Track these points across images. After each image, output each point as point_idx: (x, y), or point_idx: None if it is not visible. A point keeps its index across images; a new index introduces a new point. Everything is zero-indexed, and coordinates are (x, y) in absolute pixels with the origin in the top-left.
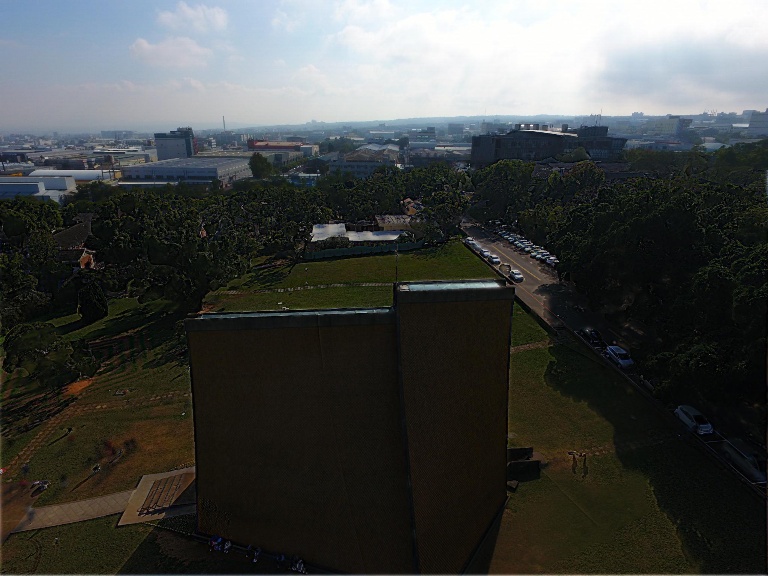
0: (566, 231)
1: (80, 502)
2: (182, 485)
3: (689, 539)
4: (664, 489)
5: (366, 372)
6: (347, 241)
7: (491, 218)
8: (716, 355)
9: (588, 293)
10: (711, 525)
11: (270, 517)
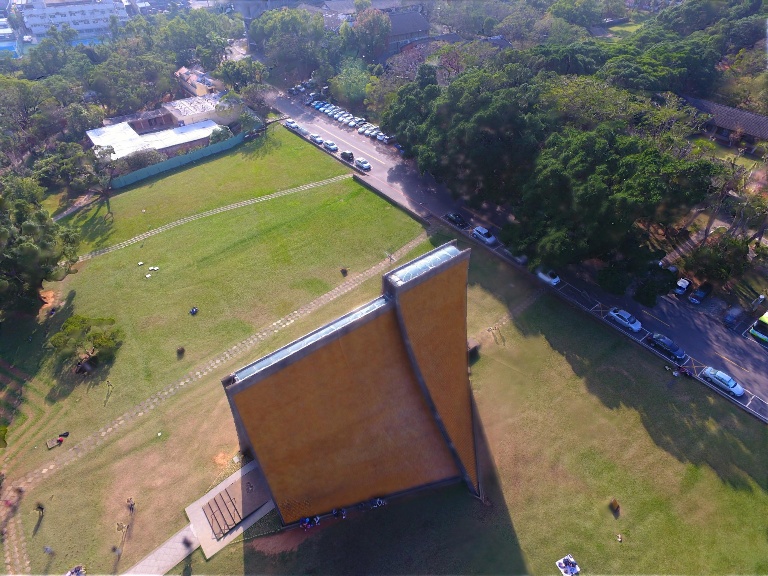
0: (401, 115)
1: (142, 563)
2: (236, 498)
3: (574, 362)
4: (550, 334)
5: (379, 353)
6: (157, 154)
7: (290, 82)
8: (569, 239)
9: (447, 184)
10: (581, 348)
11: (342, 485)
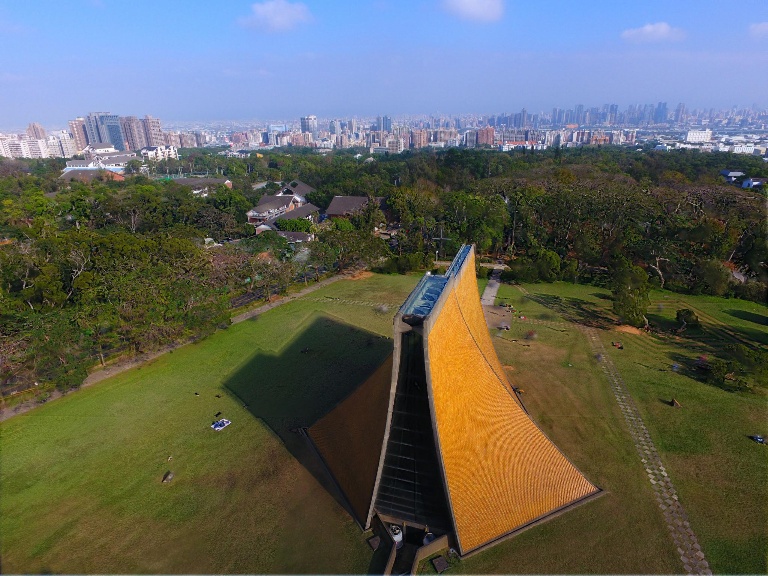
0: None
1: None
2: None
3: None
4: None
5: None
6: None
7: None
8: None
9: None
10: None
11: None
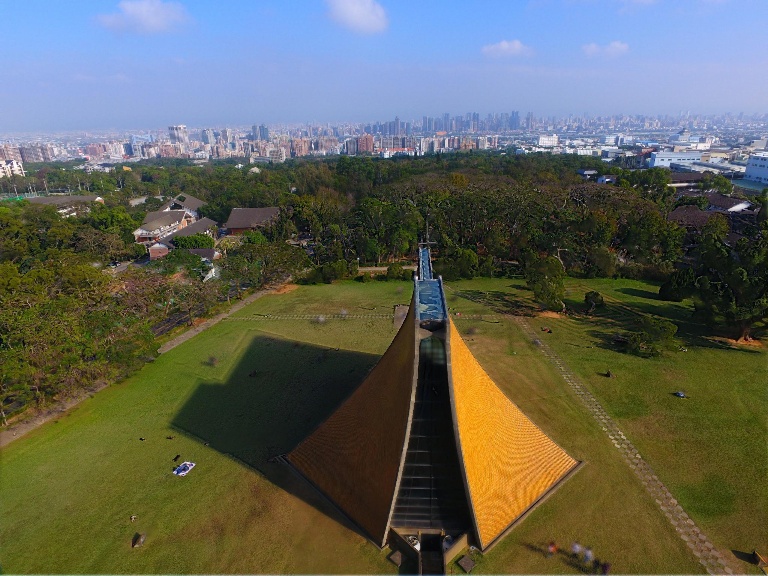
0: None
1: None
2: None
3: None
4: None
5: None
6: None
7: None
8: None
9: None
10: None
11: None
